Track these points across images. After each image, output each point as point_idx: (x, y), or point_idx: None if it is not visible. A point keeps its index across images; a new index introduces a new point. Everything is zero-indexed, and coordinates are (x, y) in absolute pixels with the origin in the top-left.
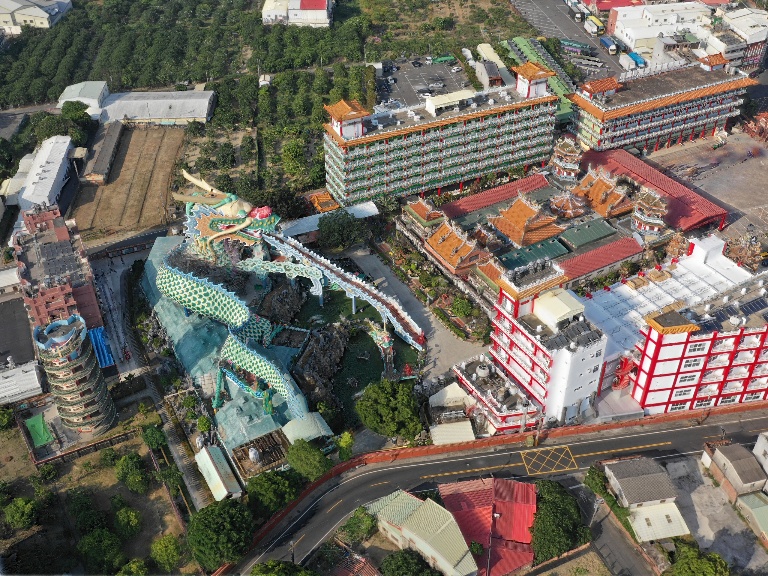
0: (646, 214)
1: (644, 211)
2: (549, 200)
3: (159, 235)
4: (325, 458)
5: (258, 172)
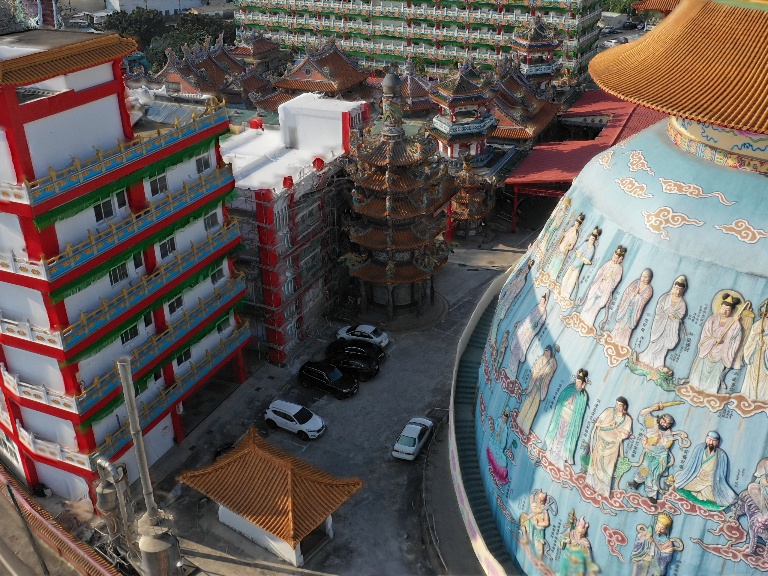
0: None
1: (467, 118)
2: None
3: None
4: None
5: None
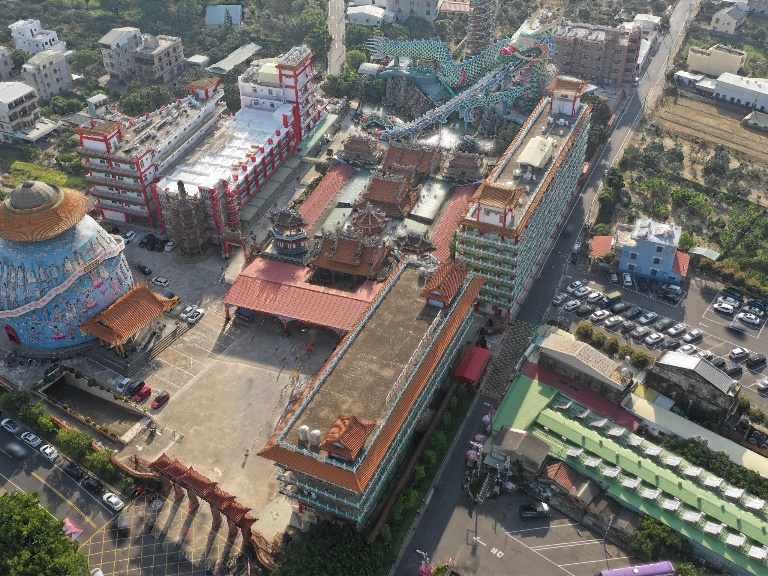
0: (292, 231)
1: None
2: (396, 232)
3: (631, 117)
4: (348, 60)
5: (672, 174)
